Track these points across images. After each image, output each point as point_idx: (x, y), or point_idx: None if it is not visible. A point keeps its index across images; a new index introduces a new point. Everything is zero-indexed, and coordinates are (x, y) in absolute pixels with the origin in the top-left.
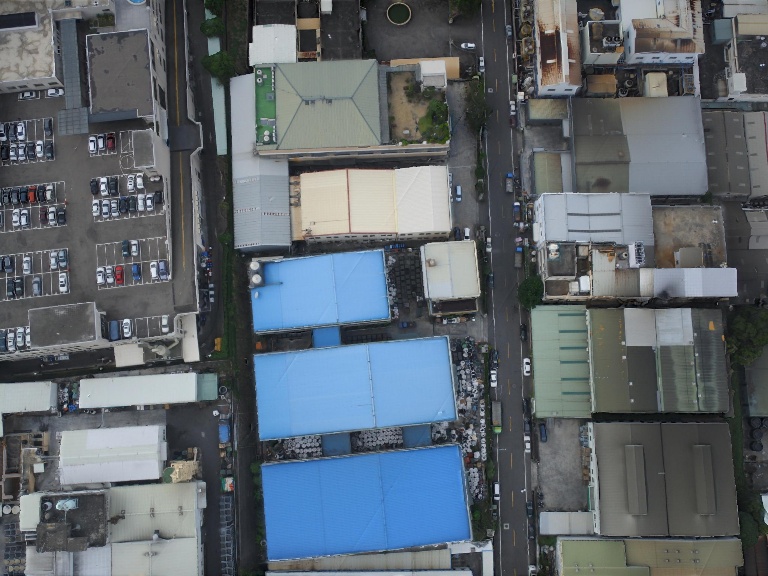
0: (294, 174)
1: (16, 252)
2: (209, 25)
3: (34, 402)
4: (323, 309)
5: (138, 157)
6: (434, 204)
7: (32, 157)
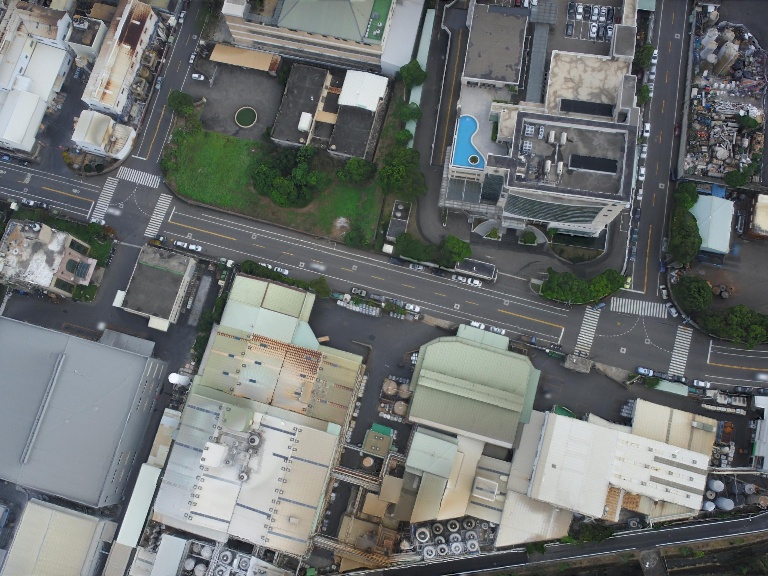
0: None
1: None
2: (413, 111)
3: None
4: None
5: None
6: None
7: (587, 7)
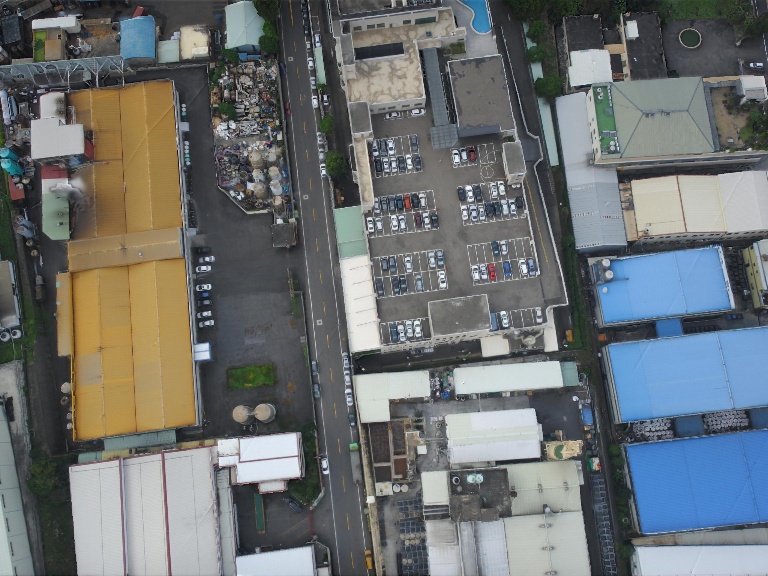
0: (621, 182)
1: (396, 253)
2: (536, 51)
3: (416, 389)
4: (671, 301)
5: (511, 166)
6: (760, 205)
7: (403, 169)
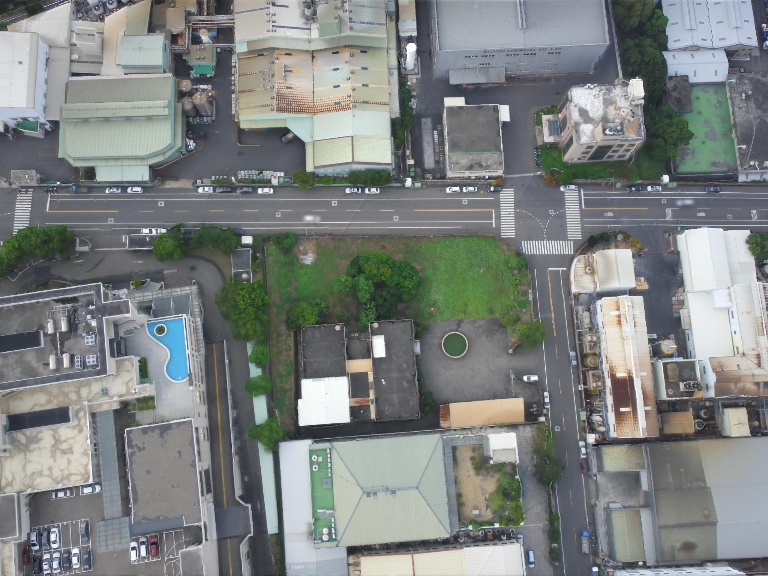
0: (352, 551)
1: None
2: (255, 386)
3: None
4: None
5: None
6: None
7: (68, 569)
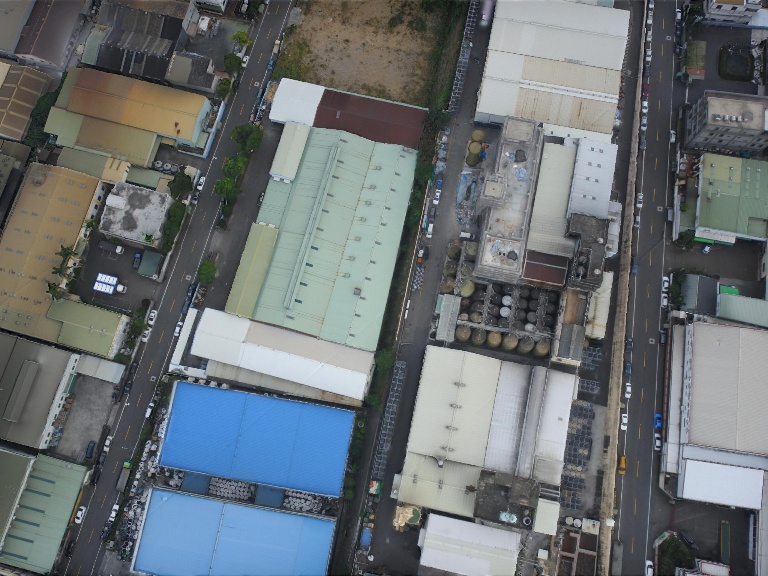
0: None
1: None
2: None
3: None
4: None
5: None
6: None
7: None
